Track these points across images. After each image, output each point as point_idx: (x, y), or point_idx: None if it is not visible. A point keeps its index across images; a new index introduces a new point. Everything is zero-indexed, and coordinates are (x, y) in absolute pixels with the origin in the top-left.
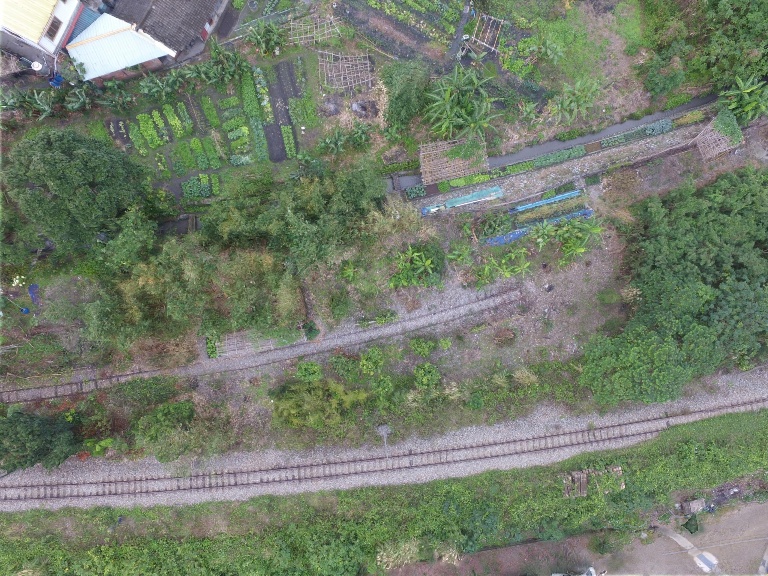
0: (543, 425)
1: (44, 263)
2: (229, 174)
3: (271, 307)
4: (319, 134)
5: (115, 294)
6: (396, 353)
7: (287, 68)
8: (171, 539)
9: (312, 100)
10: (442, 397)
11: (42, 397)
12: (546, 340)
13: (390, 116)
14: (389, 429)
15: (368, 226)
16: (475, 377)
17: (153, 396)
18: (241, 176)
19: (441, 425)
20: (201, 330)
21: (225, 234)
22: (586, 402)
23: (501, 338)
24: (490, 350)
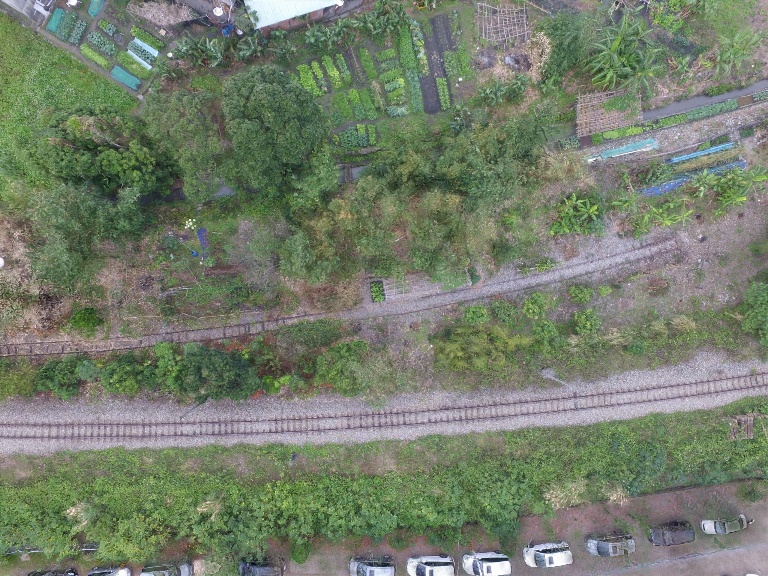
0: (706, 370)
1: (210, 208)
2: (385, 125)
3: (451, 247)
4: (473, 87)
5: (305, 231)
6: (551, 301)
7: (443, 21)
8: (342, 476)
9: (466, 53)
10: (602, 343)
11: (211, 338)
12: (698, 290)
13: (549, 67)
14: (553, 372)
15: (538, 171)
16: (630, 325)
17: (319, 338)
18: (398, 126)
19: (604, 369)
20: (379, 270)
21: (405, 176)
22: (747, 348)
23: (656, 287)
24: (643, 299)
